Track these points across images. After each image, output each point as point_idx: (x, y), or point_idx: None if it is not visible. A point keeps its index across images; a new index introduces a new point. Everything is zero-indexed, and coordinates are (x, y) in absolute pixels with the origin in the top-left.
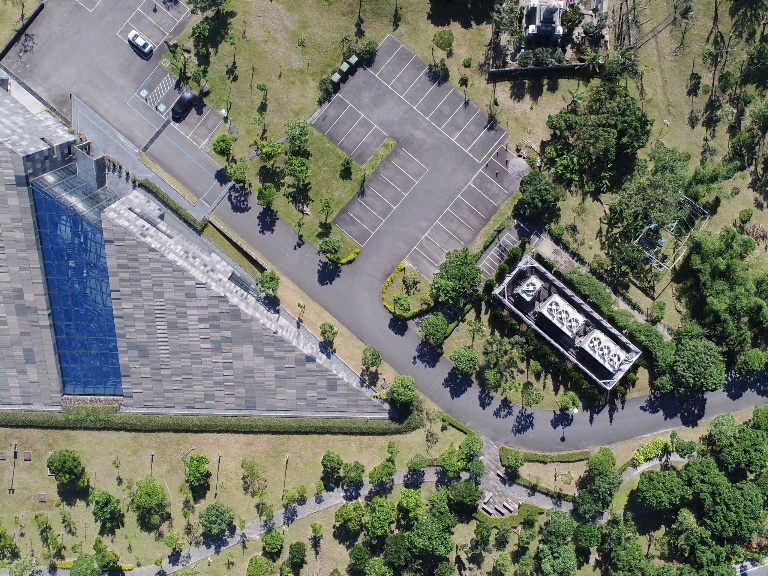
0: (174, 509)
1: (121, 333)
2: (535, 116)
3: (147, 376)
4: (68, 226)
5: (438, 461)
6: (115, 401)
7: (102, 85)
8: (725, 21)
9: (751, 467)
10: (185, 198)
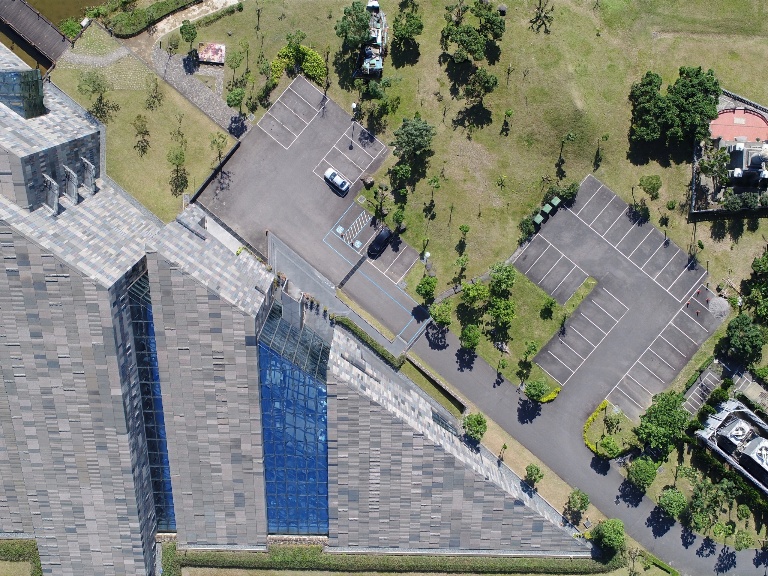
0: None
1: (334, 479)
2: (735, 255)
3: (355, 518)
4: (277, 371)
5: None
6: (320, 541)
7: (298, 222)
8: None
9: None
10: (382, 335)
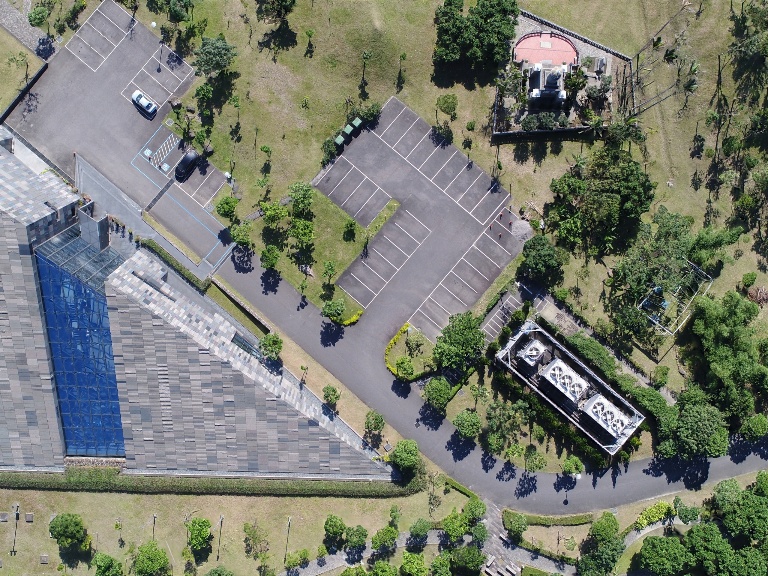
0: (176, 571)
1: (124, 397)
2: (538, 178)
3: (150, 439)
4: (71, 289)
5: (441, 524)
6: (117, 463)
7: (106, 144)
8: (728, 85)
9: (755, 534)
10: (188, 258)
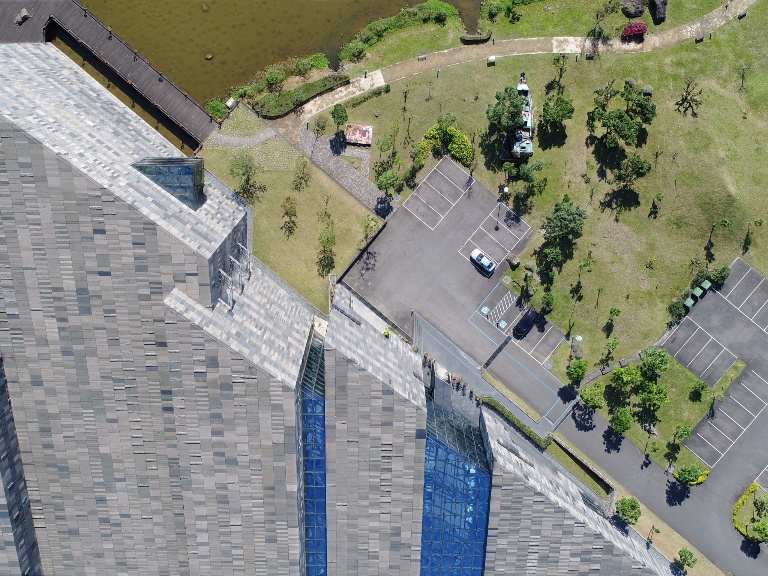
0: None
1: (490, 566)
2: None
3: None
4: (431, 455)
5: None
6: None
7: (443, 302)
8: None
9: None
10: (528, 416)
